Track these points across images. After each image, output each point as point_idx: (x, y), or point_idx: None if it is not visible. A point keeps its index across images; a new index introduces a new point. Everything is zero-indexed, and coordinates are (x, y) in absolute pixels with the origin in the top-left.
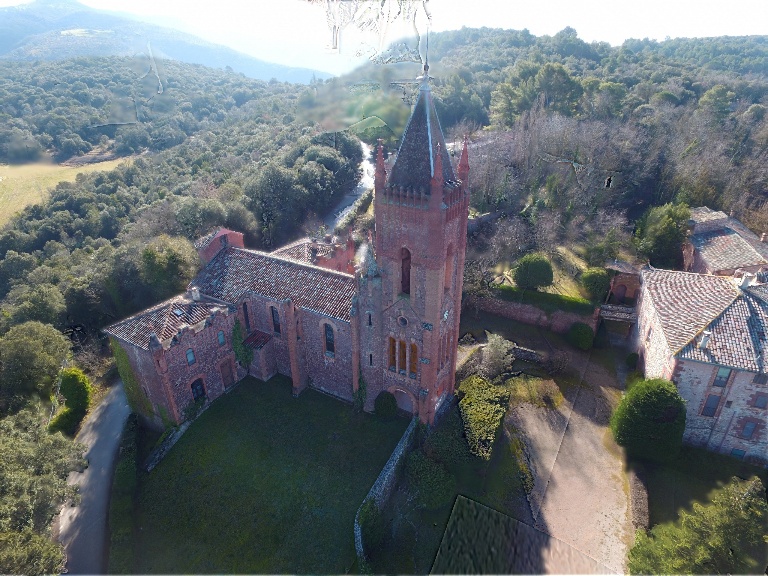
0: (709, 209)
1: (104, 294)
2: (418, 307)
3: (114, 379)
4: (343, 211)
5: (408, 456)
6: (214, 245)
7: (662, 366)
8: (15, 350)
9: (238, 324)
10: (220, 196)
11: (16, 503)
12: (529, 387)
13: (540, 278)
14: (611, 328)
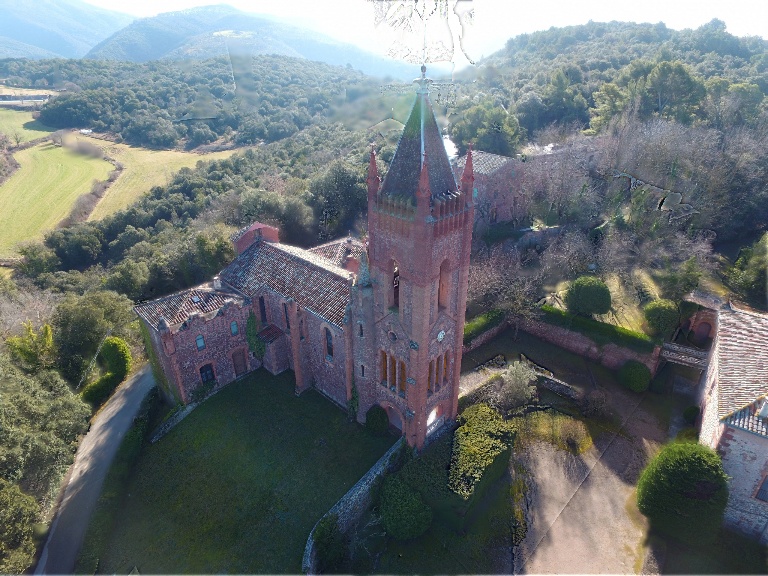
0: None
1: (178, 272)
2: (406, 324)
3: None
4: None
5: (386, 477)
6: (247, 238)
7: (713, 429)
8: (82, 315)
9: (253, 316)
10: (287, 190)
11: (7, 453)
12: (554, 425)
13: (593, 304)
14: (680, 371)
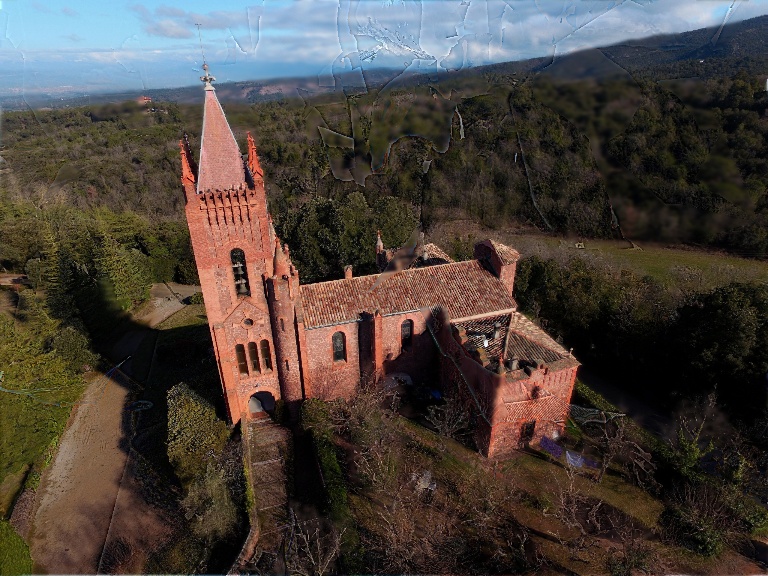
0: None
1: None
2: None
3: None
4: None
5: None
6: (481, 249)
7: None
8: None
9: None
10: None
11: None
12: (164, 574)
13: None
14: None
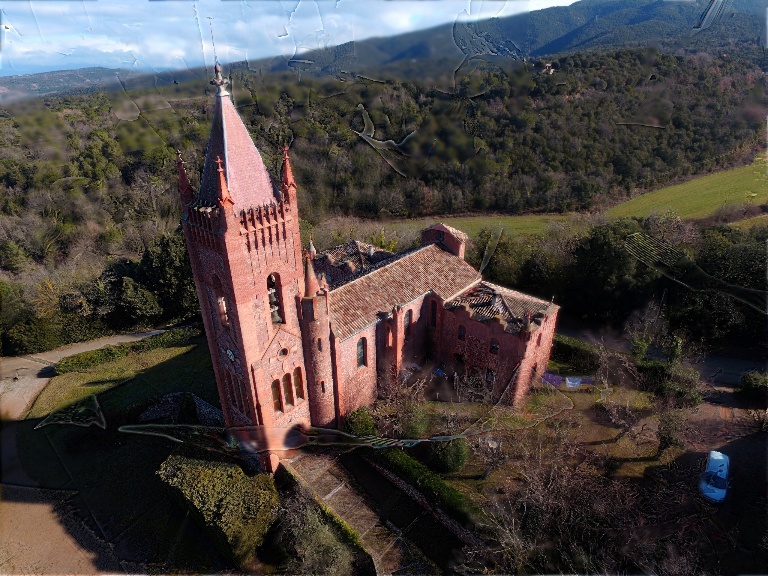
0: None
1: None
2: None
3: None
4: None
5: None
6: (431, 234)
7: None
8: None
9: None
10: None
11: None
12: None
13: None
14: None
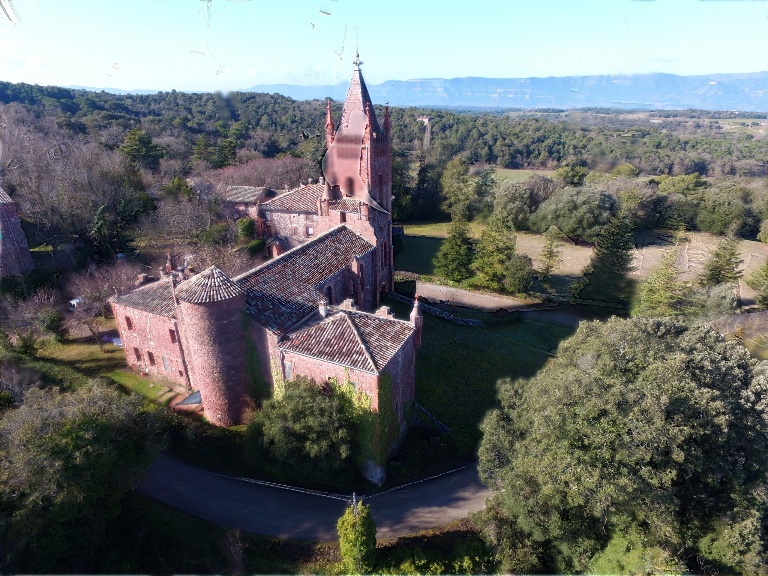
0: (185, 178)
1: None
2: None
3: (293, 553)
4: None
5: None
6: None
7: None
8: None
9: None
10: None
11: None
12: None
13: None
14: None
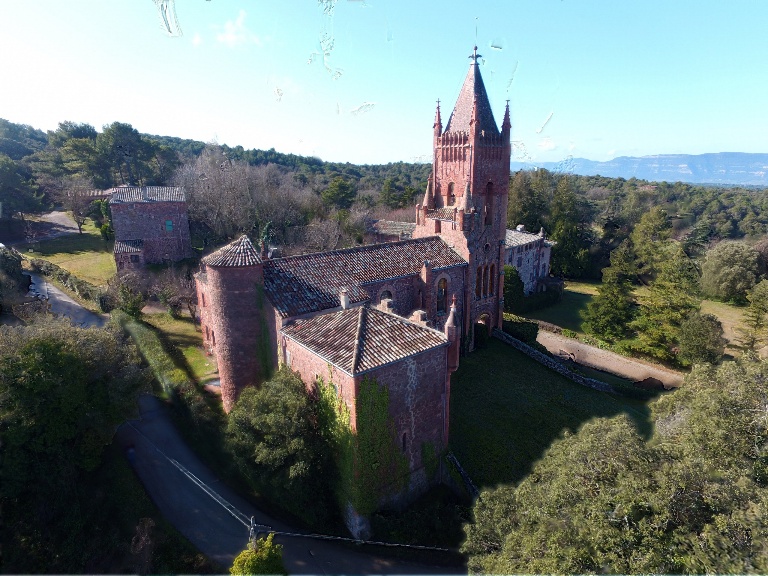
0: None
1: None
2: (496, 230)
3: None
4: (37, 290)
5: None
6: None
7: None
8: None
9: None
10: None
11: None
12: None
13: None
14: None
